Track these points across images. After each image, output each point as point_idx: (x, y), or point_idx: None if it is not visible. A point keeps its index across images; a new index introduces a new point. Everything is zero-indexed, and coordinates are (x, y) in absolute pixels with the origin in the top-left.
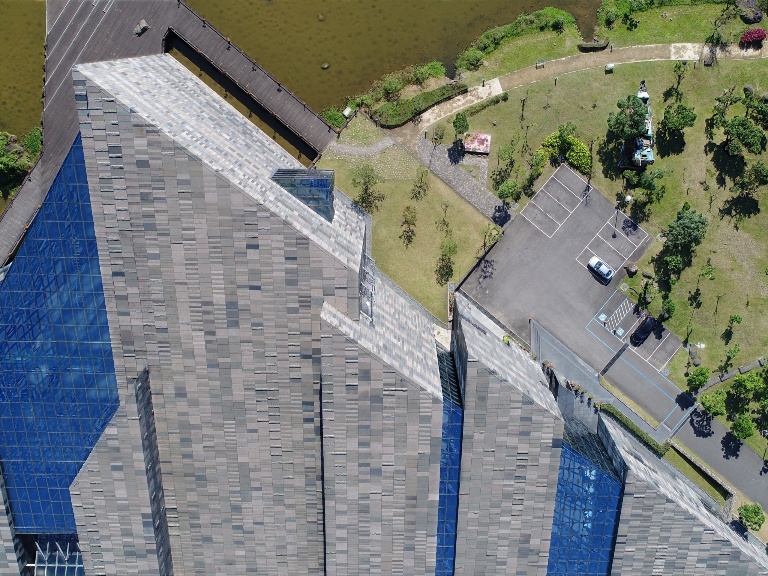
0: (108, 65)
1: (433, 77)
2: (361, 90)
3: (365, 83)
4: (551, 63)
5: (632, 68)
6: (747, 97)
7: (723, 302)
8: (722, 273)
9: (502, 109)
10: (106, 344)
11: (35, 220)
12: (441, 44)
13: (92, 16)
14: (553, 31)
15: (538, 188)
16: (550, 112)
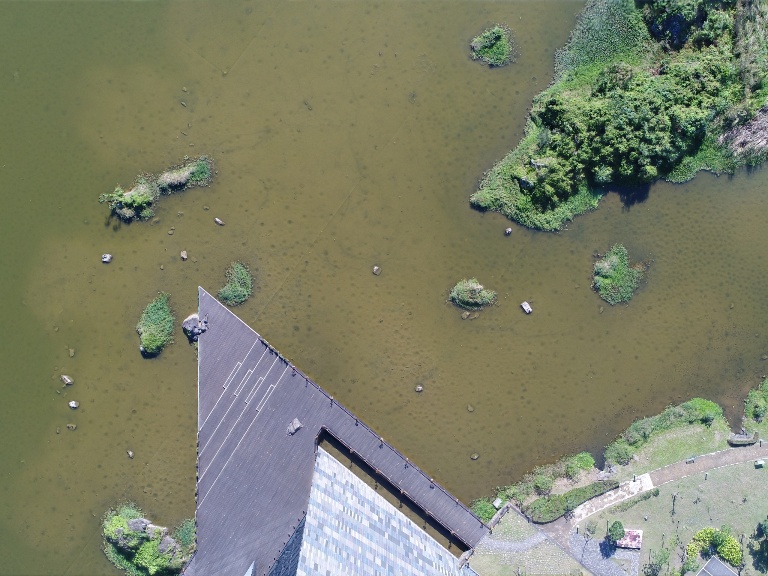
0: (303, 567)
1: (583, 469)
2: (511, 480)
3: (514, 473)
4: (701, 458)
5: None
6: None
7: None
8: None
9: (653, 504)
10: None
11: None
12: (589, 434)
13: (245, 414)
14: (702, 424)
15: None
16: (701, 506)
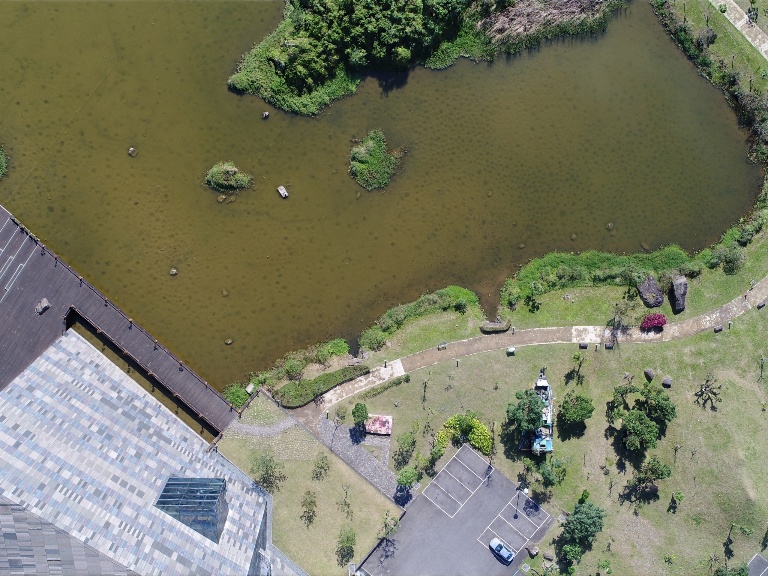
0: None
1: (336, 355)
2: (264, 366)
3: (269, 359)
4: (453, 345)
5: (534, 350)
6: (646, 387)
7: None
8: (622, 559)
9: (404, 390)
10: None
11: None
12: (345, 320)
13: None
14: (456, 311)
15: (440, 468)
16: (452, 393)
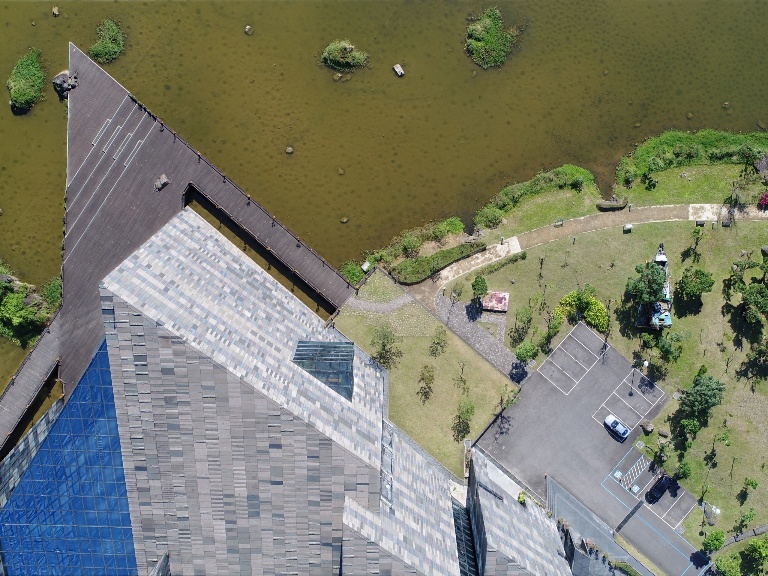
0: (133, 261)
1: (452, 233)
2: (380, 244)
3: (384, 237)
4: (570, 222)
5: (650, 228)
6: (765, 262)
7: (739, 463)
8: (738, 435)
9: (520, 267)
10: (127, 528)
11: (59, 417)
12: (460, 199)
13: (113, 170)
14: (572, 189)
15: (555, 346)
16: (568, 271)
